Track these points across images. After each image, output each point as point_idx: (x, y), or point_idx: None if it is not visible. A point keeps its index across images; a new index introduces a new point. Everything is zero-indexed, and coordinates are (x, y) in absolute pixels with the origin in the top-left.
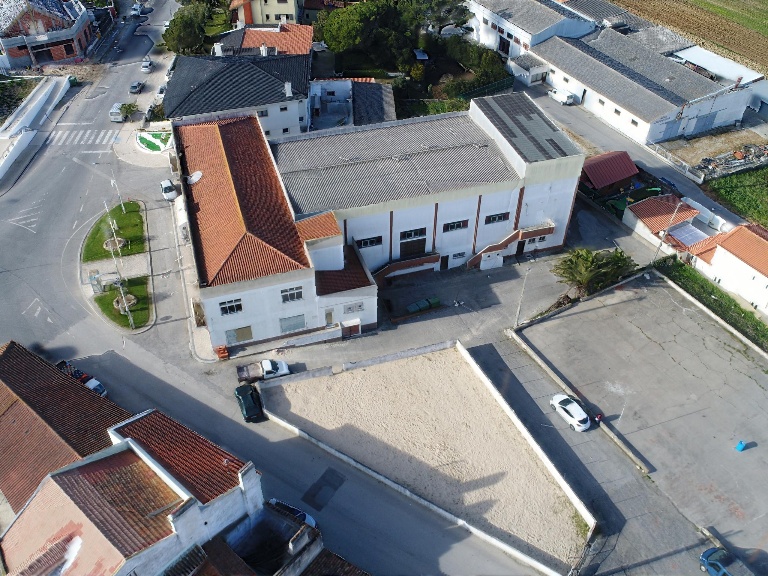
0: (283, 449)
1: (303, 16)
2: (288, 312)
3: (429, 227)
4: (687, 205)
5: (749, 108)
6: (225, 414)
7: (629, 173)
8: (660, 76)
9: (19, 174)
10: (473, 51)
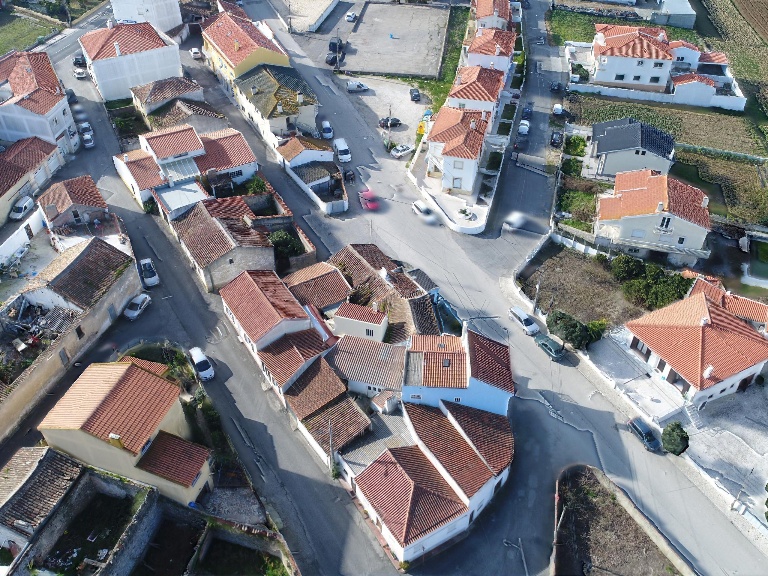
0: None
1: None
2: None
3: None
4: None
5: (657, 4)
6: None
7: None
8: None
9: None
10: None
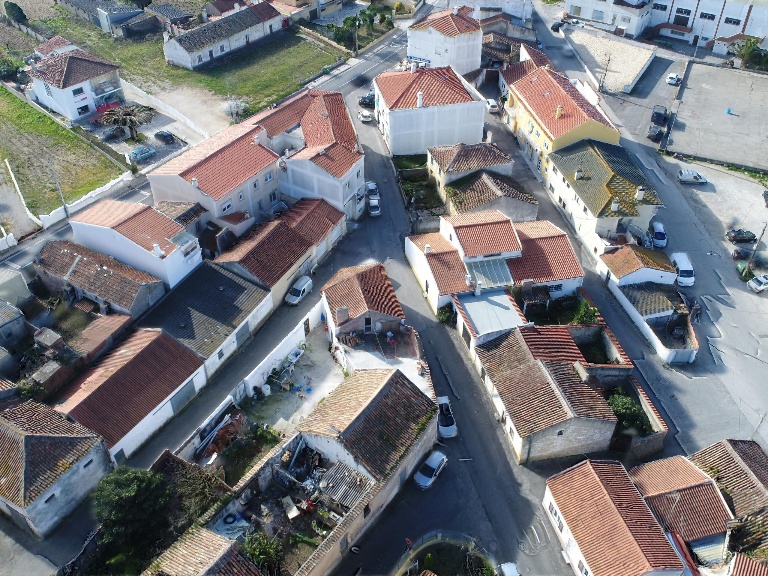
0: (555, 38)
1: None
2: (598, 7)
3: (693, 11)
4: None
5: None
6: (548, 26)
7: None
8: None
9: None
10: None
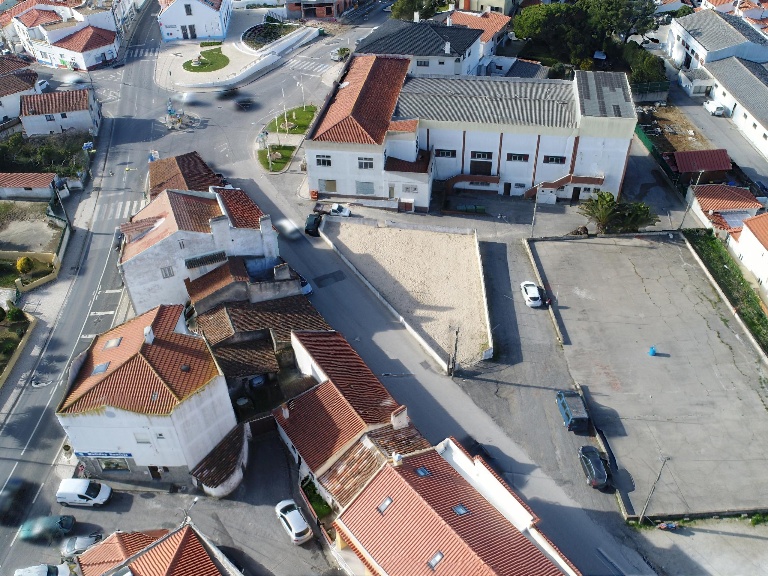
0: (319, 253)
1: (517, 13)
2: (362, 177)
3: (495, 153)
4: (754, 199)
5: None
6: (296, 227)
7: (720, 167)
8: None
9: (256, 78)
10: (639, 55)
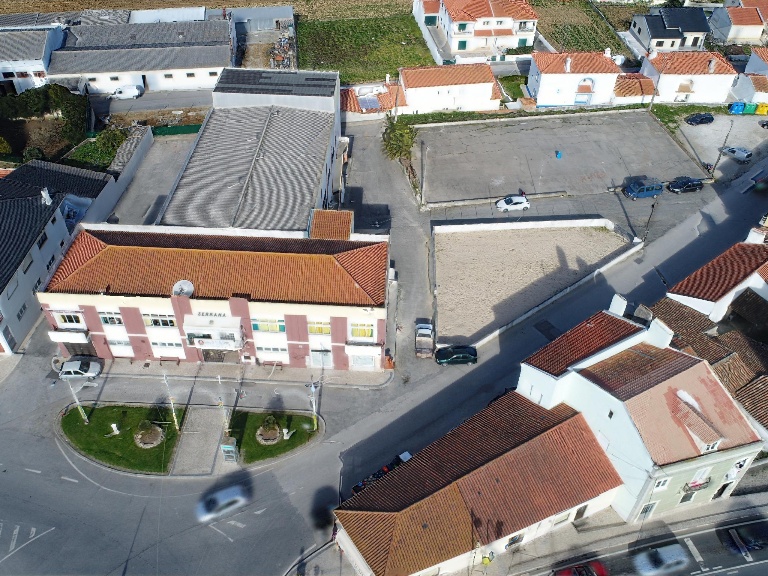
0: (509, 348)
1: None
2: None
3: None
4: None
5: None
6: (460, 377)
7: None
8: (172, 37)
9: None
10: (34, 95)
